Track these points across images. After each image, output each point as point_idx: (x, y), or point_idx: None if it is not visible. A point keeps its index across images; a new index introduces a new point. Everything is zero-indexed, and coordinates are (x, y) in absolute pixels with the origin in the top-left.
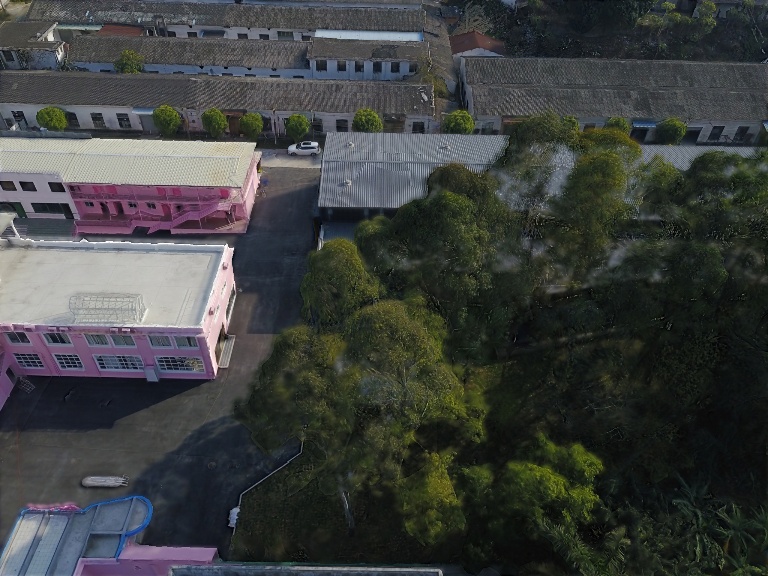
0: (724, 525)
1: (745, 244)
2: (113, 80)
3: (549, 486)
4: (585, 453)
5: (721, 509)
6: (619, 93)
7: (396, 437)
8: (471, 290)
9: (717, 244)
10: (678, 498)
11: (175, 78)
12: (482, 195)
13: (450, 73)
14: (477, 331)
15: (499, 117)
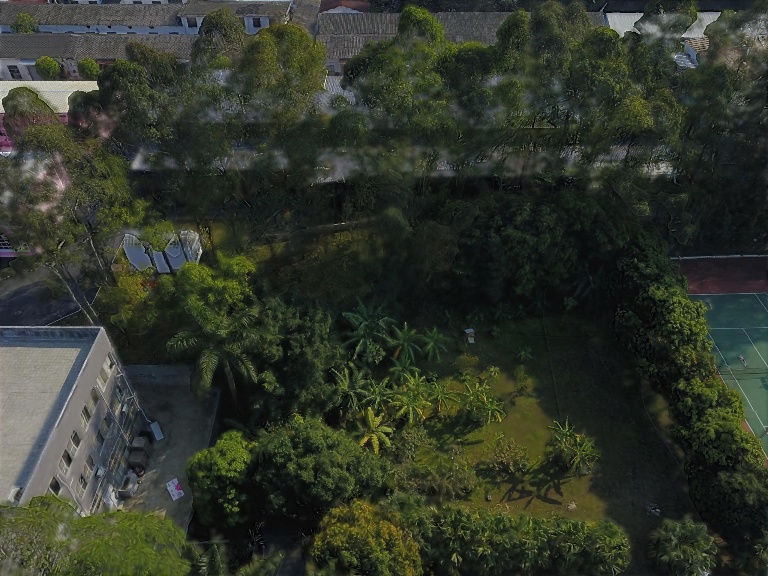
0: (395, 338)
1: (399, 113)
2: (5, 37)
3: (193, 273)
4: (242, 260)
5: (382, 320)
6: (446, 37)
7: (50, 220)
8: (151, 138)
9: (369, 110)
10: (350, 312)
11: (59, 34)
12: (153, 64)
13: (308, 27)
14: (174, 177)
15: (337, 60)
